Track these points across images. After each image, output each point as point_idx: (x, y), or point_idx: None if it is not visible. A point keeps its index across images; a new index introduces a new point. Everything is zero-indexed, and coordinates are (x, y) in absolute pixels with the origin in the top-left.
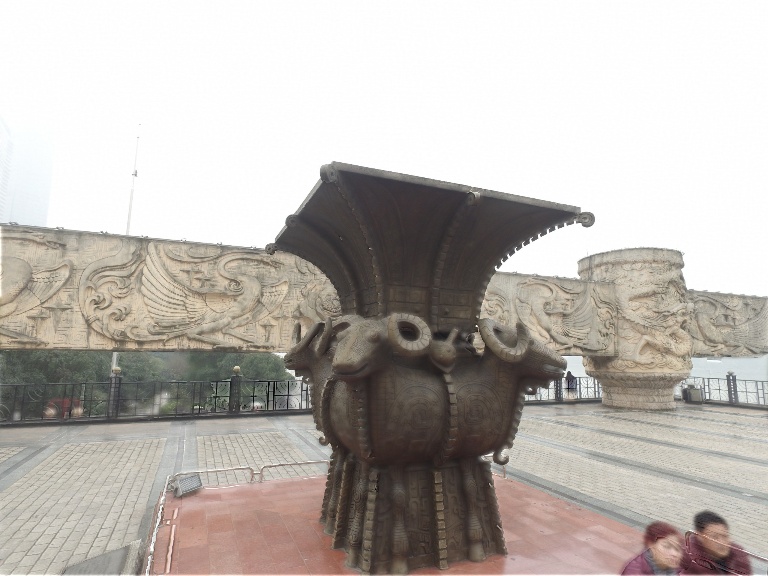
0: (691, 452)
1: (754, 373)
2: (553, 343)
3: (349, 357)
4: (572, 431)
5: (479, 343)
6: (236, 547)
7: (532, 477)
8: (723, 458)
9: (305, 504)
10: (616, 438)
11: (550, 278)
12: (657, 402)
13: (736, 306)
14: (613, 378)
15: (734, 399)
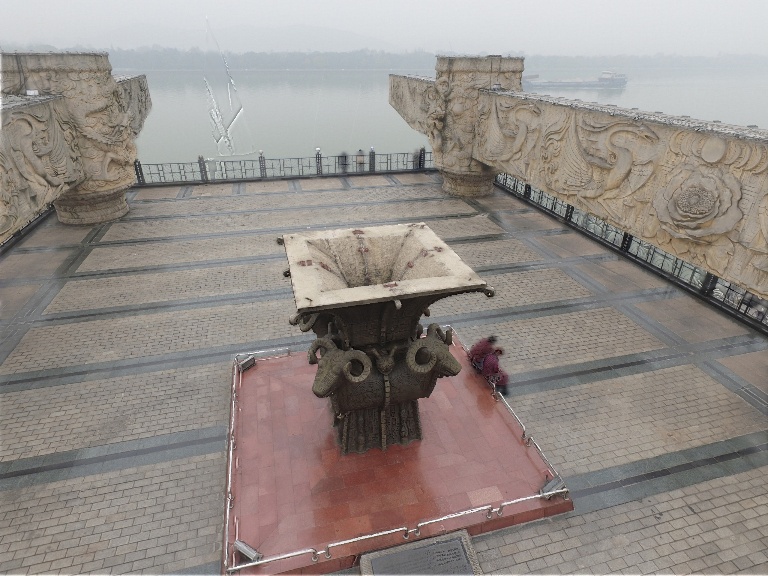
0: (250, 265)
1: (151, 156)
2: (50, 188)
3: (459, 364)
4: (152, 280)
5: (3, 224)
6: (376, 497)
7: (268, 342)
8: (269, 262)
9: (307, 464)
10: (193, 272)
11: (23, 107)
12: (121, 209)
13: (122, 93)
14: (83, 199)
15: (142, 181)
